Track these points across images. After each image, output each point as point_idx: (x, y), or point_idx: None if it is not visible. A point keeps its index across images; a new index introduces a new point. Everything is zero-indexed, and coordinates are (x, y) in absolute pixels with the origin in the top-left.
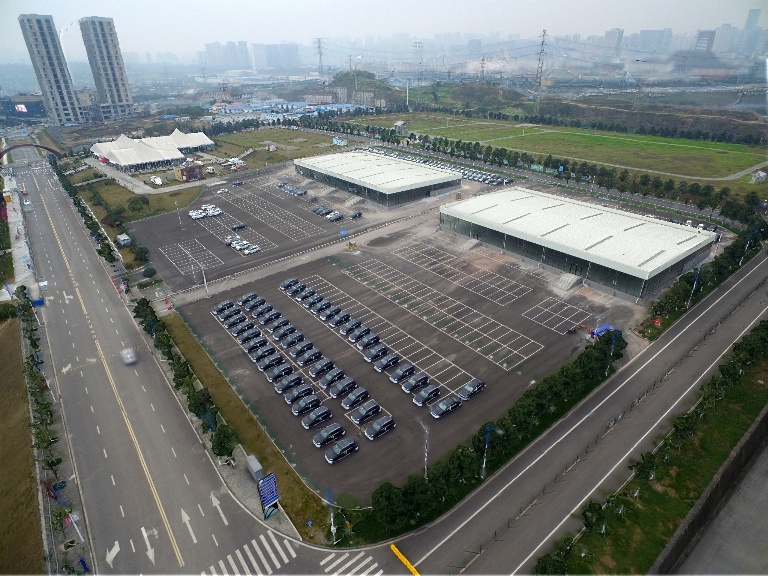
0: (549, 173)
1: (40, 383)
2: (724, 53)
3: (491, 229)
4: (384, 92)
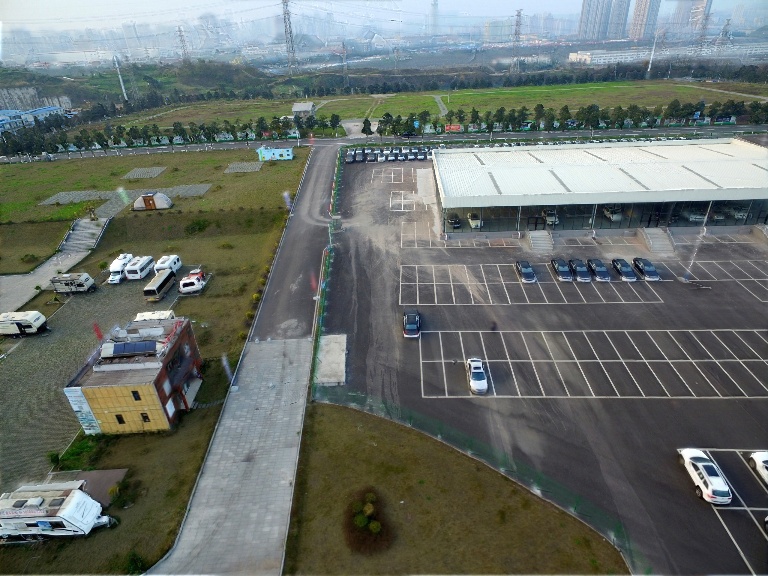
0: (673, 125)
1: None
2: (461, 11)
3: None
4: (53, 85)
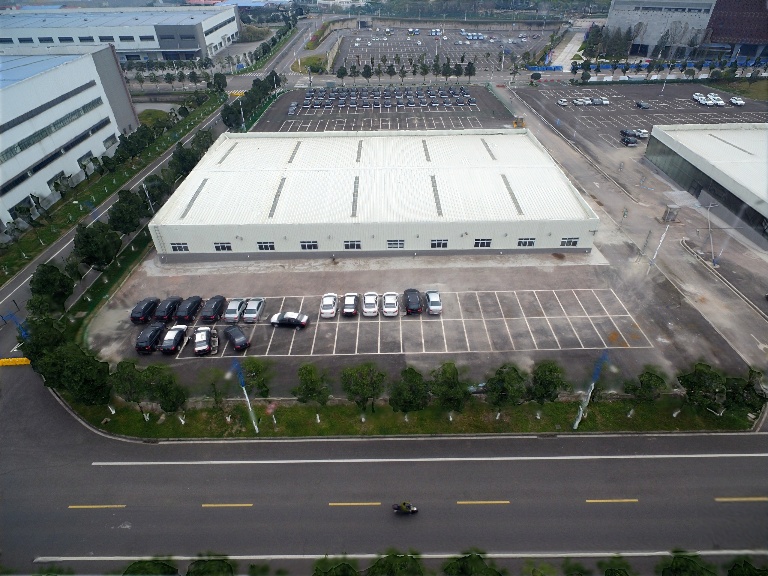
0: None
1: (422, 58)
2: None
3: None
4: None
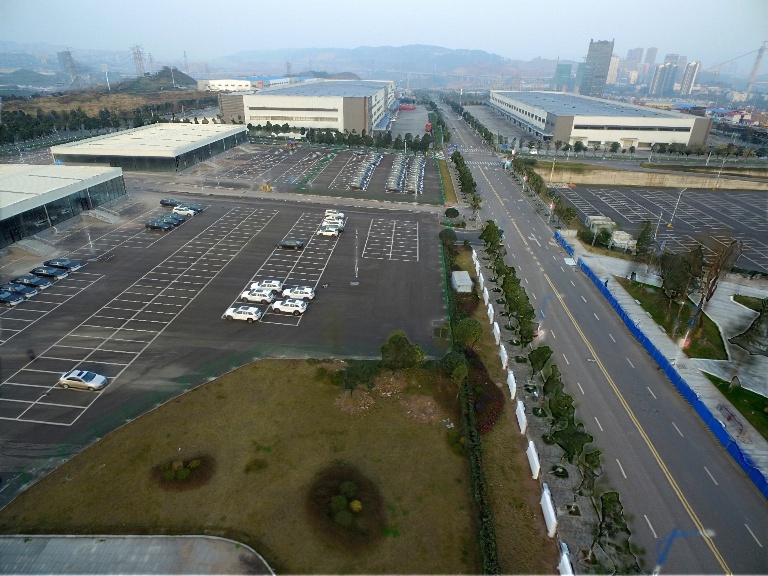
0: None
1: None
2: None
3: None
4: None
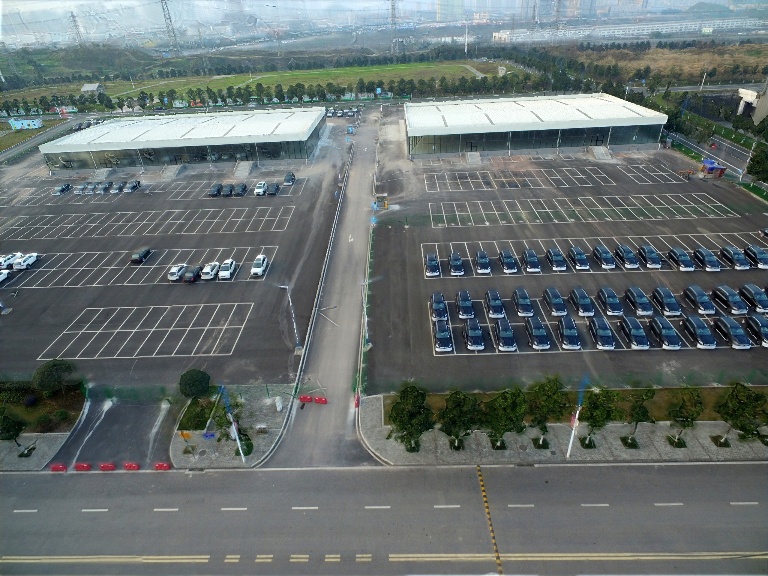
0: (365, 99)
1: None
2: None
3: (491, 132)
4: None
